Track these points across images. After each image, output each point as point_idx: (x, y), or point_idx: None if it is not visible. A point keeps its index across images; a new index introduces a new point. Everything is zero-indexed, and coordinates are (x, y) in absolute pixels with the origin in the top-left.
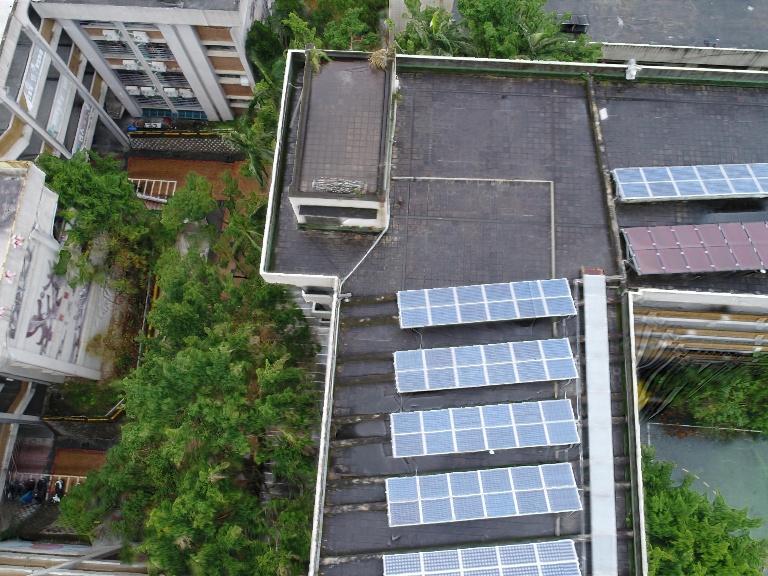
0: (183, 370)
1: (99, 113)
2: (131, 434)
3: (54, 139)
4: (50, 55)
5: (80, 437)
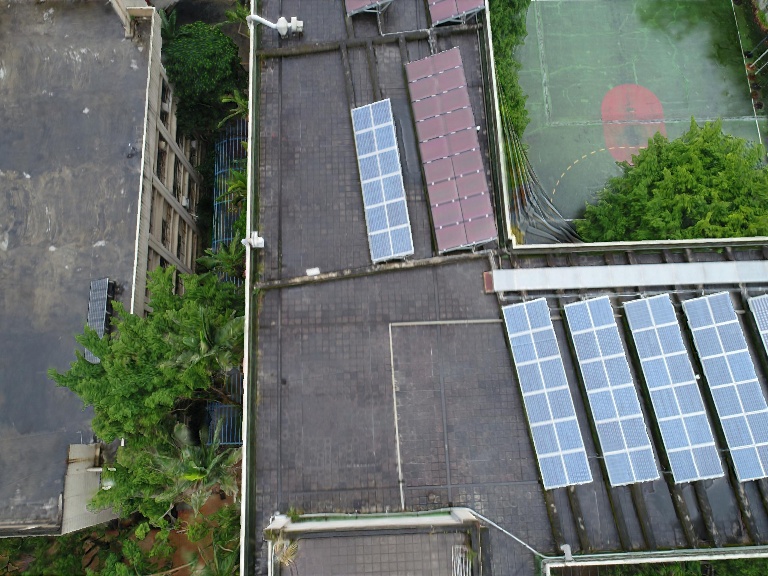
0: None
1: None
2: None
3: None
4: None
5: None
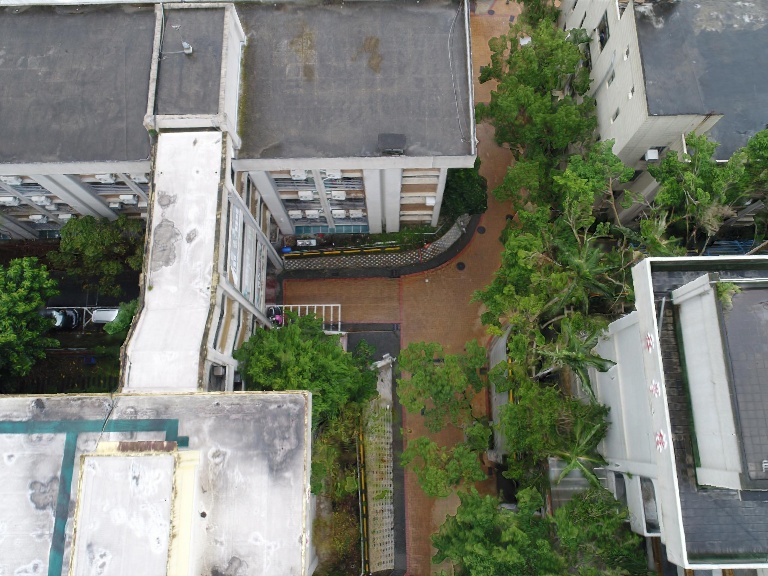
0: None
1: (267, 248)
2: None
3: (250, 303)
4: (243, 210)
5: None
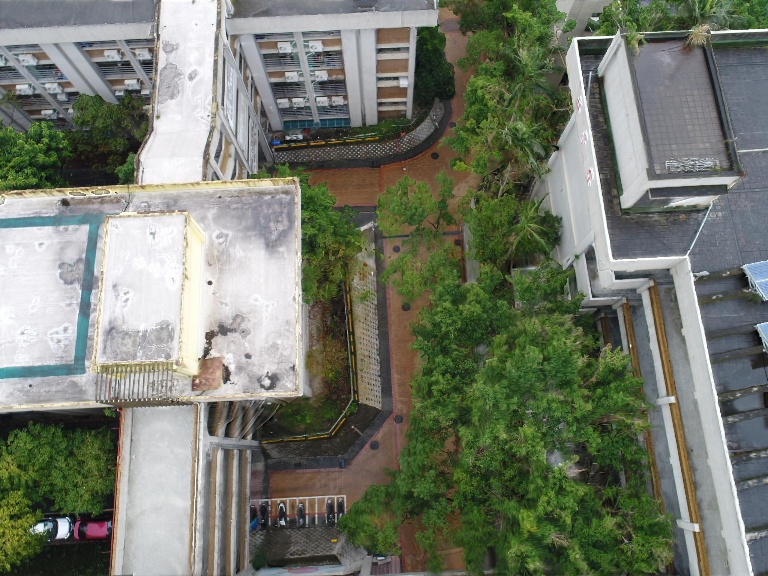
0: (536, 367)
1: (258, 129)
2: (487, 438)
3: (244, 157)
4: (237, 72)
5: (291, 458)
